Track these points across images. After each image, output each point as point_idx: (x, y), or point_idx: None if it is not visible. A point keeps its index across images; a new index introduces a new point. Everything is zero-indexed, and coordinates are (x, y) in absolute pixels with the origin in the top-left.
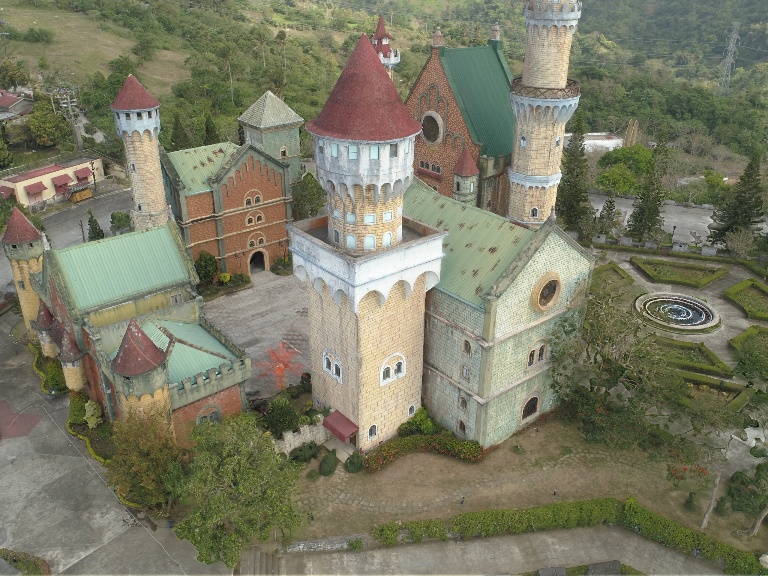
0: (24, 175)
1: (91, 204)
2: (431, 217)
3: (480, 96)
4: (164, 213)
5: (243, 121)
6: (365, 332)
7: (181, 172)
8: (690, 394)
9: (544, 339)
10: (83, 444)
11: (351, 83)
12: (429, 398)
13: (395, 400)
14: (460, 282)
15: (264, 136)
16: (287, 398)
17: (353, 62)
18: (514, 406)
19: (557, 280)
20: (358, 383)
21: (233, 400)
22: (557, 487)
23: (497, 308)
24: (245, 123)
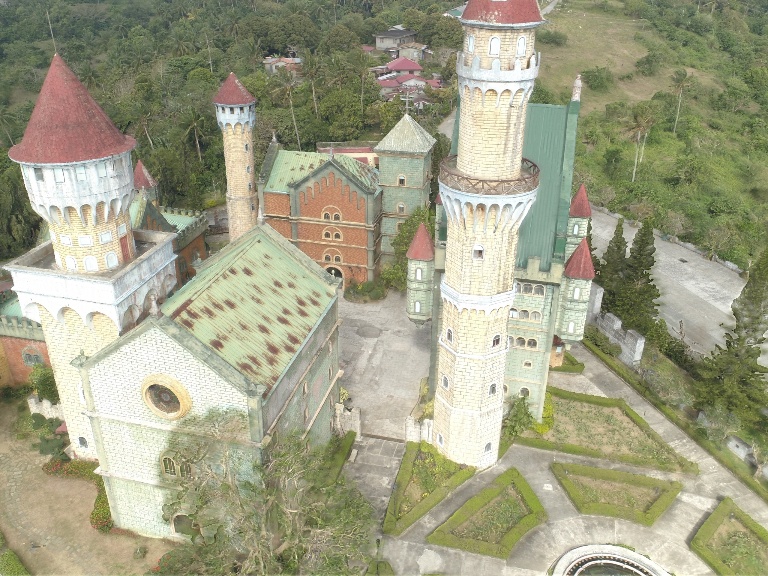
0: (338, 150)
1: None
2: None
3: None
4: (242, 200)
5: None
6: (53, 341)
7: (278, 170)
8: None
9: (183, 454)
10: None
11: None
12: None
13: None
14: None
15: (380, 158)
16: None
17: None
18: (157, 507)
19: (171, 389)
20: None
21: None
22: None
23: (91, 378)
24: None
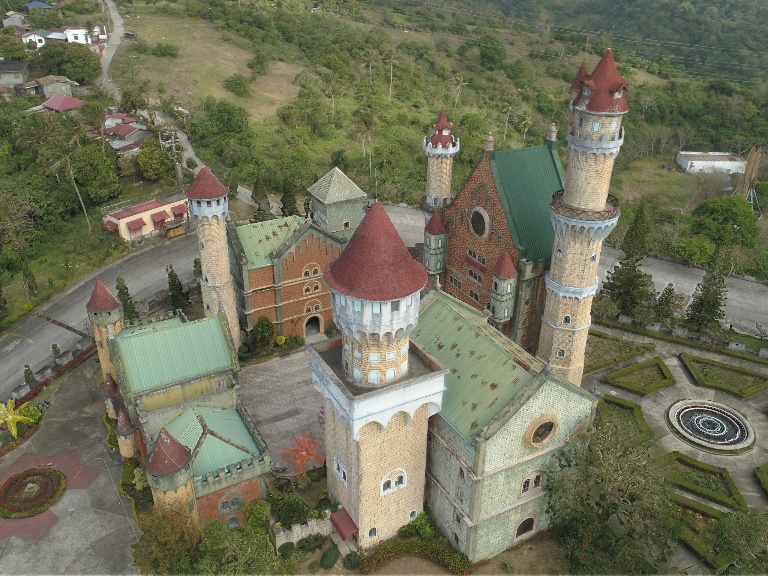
0: (128, 210)
1: (183, 241)
2: (448, 338)
3: (528, 197)
4: (227, 285)
5: (311, 193)
6: (366, 452)
7: (247, 246)
8: (695, 527)
9: (540, 469)
10: (130, 504)
11: (361, 244)
12: (432, 503)
13: (396, 506)
14: (460, 413)
15: (328, 210)
16: (307, 482)
17: (365, 225)
18: (507, 526)
19: (552, 421)
20: (358, 494)
21: (253, 488)
22: None
23: (487, 447)
24: (313, 195)
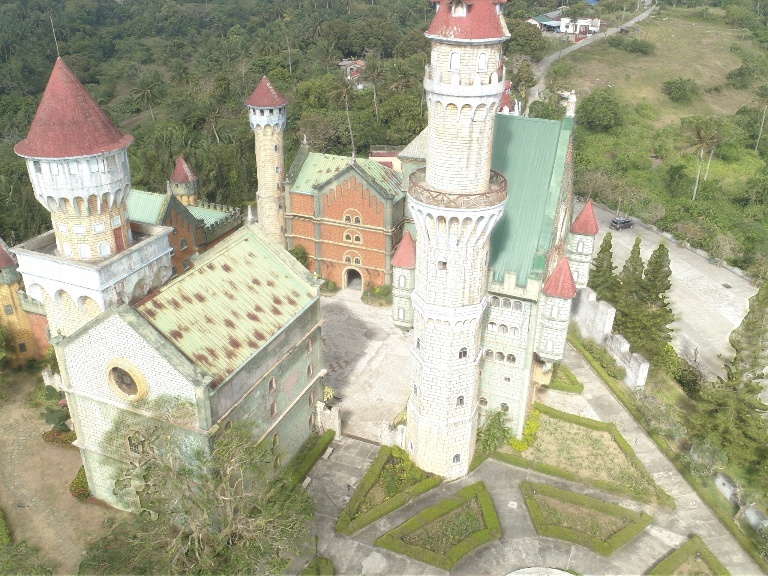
0: (391, 153)
1: None
2: None
3: None
4: (270, 199)
5: None
6: (54, 320)
7: (306, 171)
8: None
9: (144, 434)
10: None
11: None
12: None
13: None
14: None
15: (404, 164)
16: None
17: None
18: None
19: (129, 372)
20: None
21: None
22: (54, 568)
23: (67, 356)
24: None
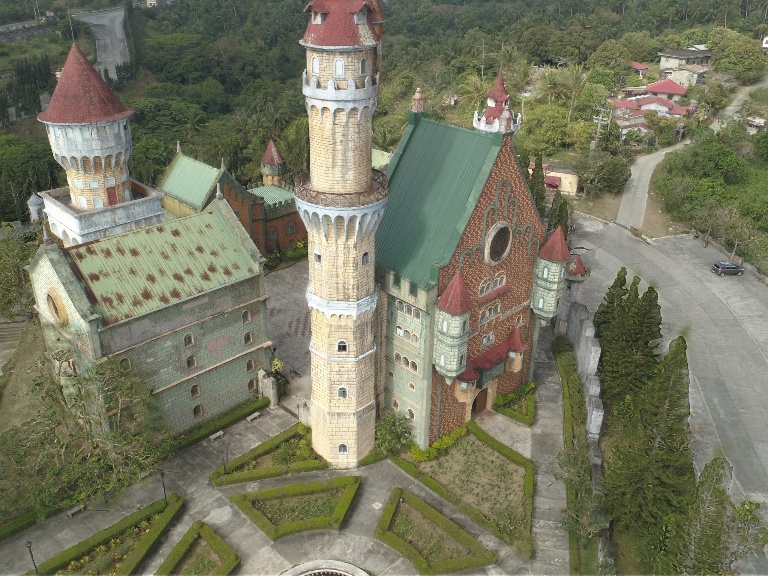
0: None
1: None
2: None
3: (421, 187)
4: None
5: None
6: None
7: None
8: (91, 568)
9: None
10: None
11: None
12: None
13: None
14: None
15: None
16: None
17: None
18: None
19: (54, 300)
20: None
21: None
22: None
23: None
24: None
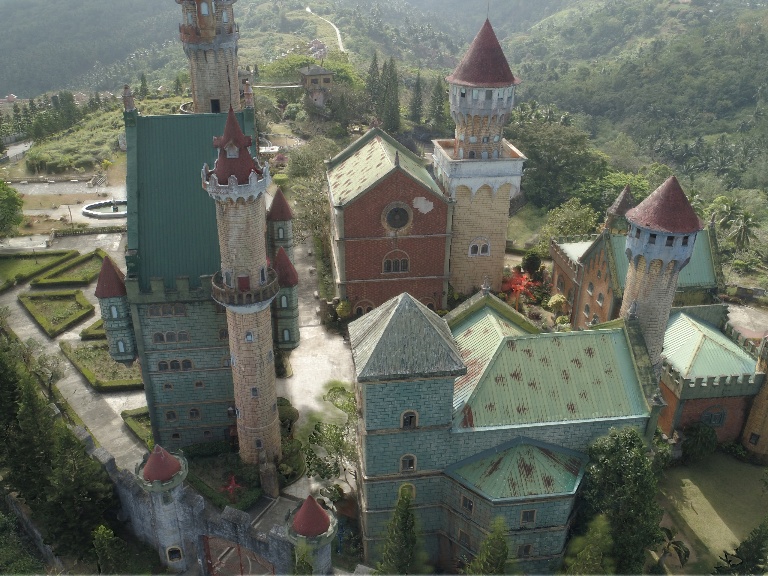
0: None
1: None
2: None
3: None
4: None
5: None
6: None
7: None
8: None
9: None
10: None
11: None
12: None
13: None
14: None
15: None
16: None
17: None
18: None
19: None
20: None
21: None
22: None
23: None
24: None
